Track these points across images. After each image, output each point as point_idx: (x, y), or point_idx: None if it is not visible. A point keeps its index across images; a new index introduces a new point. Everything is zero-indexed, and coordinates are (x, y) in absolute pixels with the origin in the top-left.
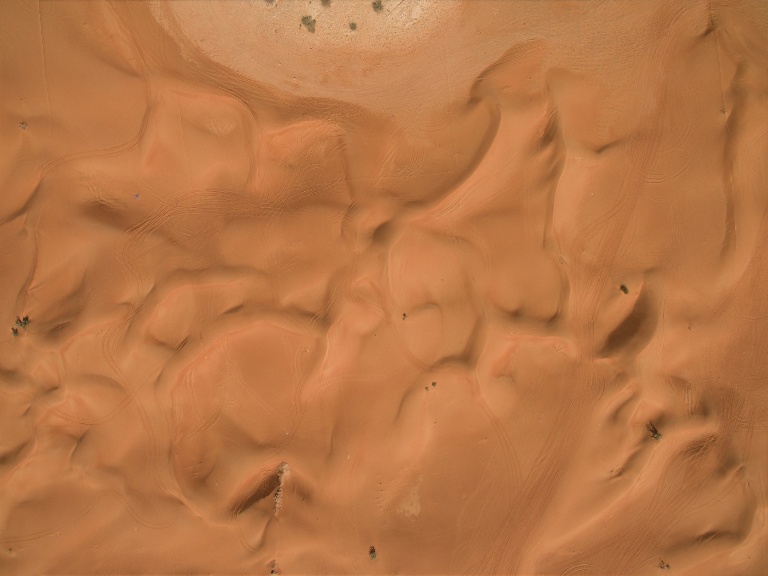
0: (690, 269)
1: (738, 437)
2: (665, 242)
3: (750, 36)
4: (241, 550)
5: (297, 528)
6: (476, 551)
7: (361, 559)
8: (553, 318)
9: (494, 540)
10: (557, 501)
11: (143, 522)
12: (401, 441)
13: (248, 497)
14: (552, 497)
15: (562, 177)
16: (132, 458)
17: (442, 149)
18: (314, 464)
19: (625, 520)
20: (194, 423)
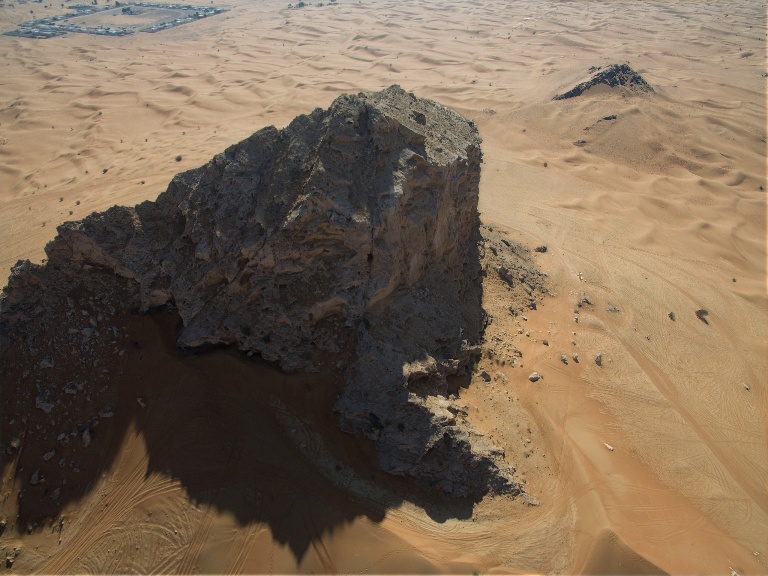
0: (731, 57)
1: None
2: (737, 59)
3: None
4: None
5: None
6: None
7: None
8: (767, 57)
9: None
10: None
11: None
12: None
13: None
14: None
15: None
16: None
17: None
18: None
19: None
20: None
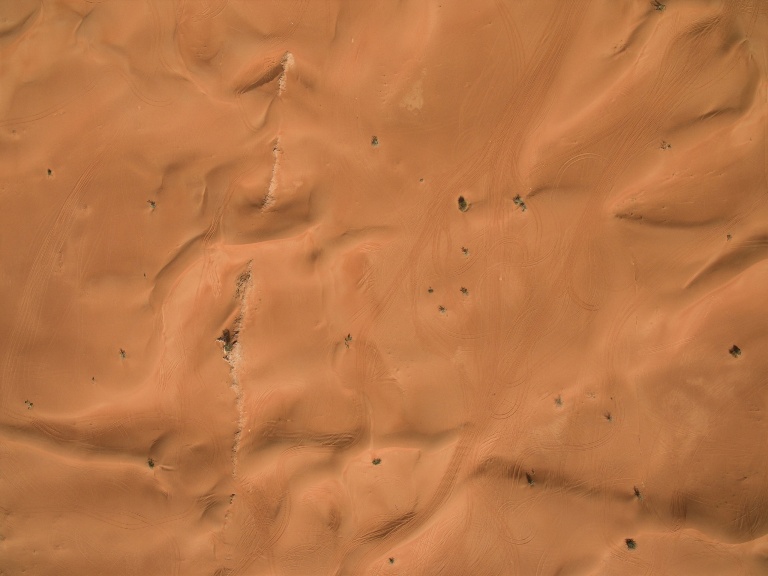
0: None
1: (742, 18)
2: None
3: None
4: (244, 131)
5: (300, 111)
6: (478, 137)
7: (363, 149)
8: None
9: (496, 125)
10: (560, 79)
11: (147, 100)
12: (405, 25)
13: (252, 83)
14: (555, 76)
15: None
16: (137, 40)
17: None
18: (318, 51)
19: (627, 105)
20: (199, 8)
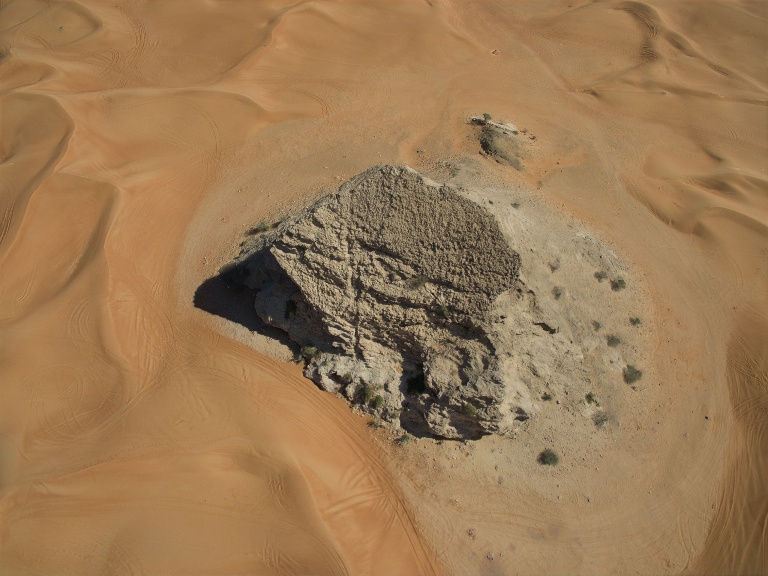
0: None
1: None
2: None
3: (593, 79)
4: None
5: None
6: None
7: None
8: None
9: None
10: None
11: None
12: None
13: None
14: None
15: (765, 180)
16: None
17: (763, 268)
18: None
19: None
20: None
